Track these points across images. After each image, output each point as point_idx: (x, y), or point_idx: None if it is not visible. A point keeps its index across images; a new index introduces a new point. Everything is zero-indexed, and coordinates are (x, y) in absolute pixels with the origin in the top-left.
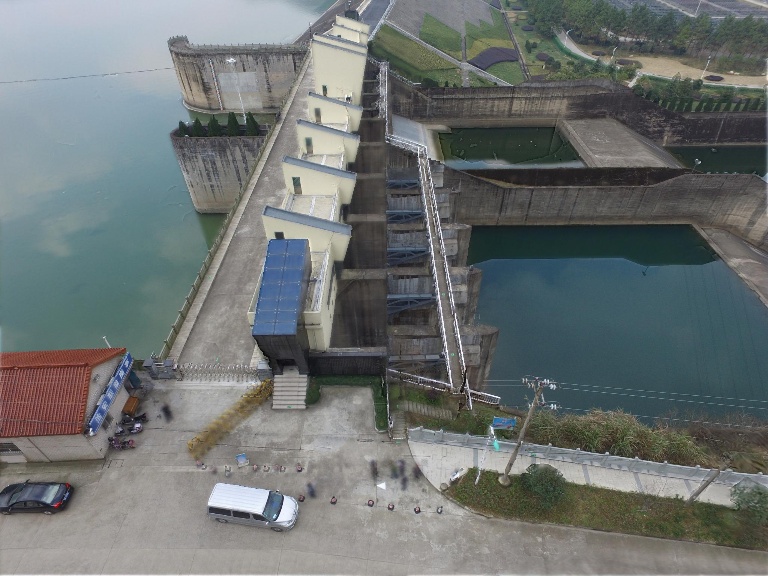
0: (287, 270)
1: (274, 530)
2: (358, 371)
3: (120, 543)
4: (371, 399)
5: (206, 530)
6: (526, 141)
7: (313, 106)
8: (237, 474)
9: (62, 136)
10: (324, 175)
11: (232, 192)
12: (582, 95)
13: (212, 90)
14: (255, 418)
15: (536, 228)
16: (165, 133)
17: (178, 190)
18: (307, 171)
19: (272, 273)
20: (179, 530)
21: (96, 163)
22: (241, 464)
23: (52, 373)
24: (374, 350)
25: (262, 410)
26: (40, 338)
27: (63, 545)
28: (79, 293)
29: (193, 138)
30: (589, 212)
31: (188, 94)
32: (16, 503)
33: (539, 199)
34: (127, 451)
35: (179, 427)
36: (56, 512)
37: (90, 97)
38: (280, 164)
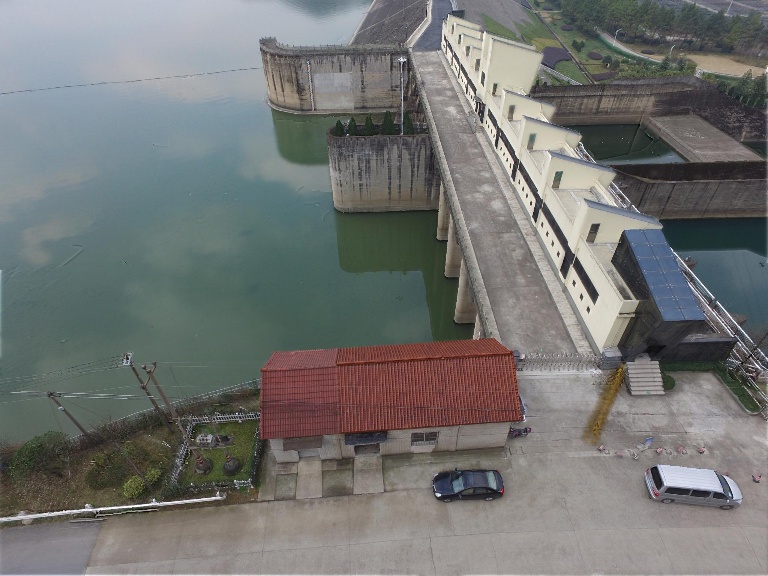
0: (660, 259)
1: (721, 508)
2: (699, 357)
3: (579, 525)
4: (719, 383)
5: (653, 510)
6: (609, 138)
7: (509, 103)
8: (643, 457)
9: (158, 138)
10: (588, 169)
11: (379, 191)
12: (669, 92)
13: (306, 91)
14: (621, 404)
15: (670, 222)
16: (264, 134)
17: (308, 190)
18: (573, 165)
19: (646, 262)
20: (627, 511)
21: (209, 165)
22: (642, 448)
23: (478, 362)
24: (718, 336)
25: (622, 396)
26: (241, 338)
27: (524, 529)
28: (259, 293)
29: (354, 137)
30: (724, 205)
31: (279, 95)
32: (465, 490)
33: (679, 193)
34: (521, 439)
35: (553, 415)
36: (496, 498)
37: (177, 99)
38: (461, 161)
